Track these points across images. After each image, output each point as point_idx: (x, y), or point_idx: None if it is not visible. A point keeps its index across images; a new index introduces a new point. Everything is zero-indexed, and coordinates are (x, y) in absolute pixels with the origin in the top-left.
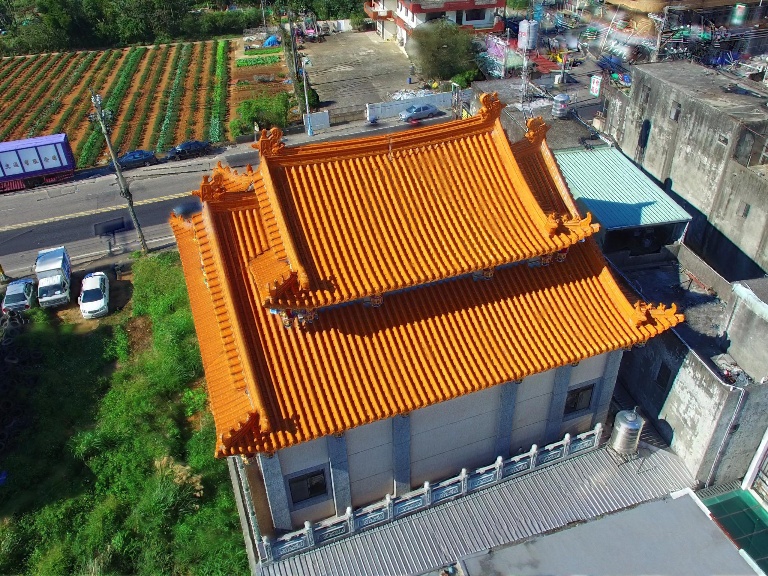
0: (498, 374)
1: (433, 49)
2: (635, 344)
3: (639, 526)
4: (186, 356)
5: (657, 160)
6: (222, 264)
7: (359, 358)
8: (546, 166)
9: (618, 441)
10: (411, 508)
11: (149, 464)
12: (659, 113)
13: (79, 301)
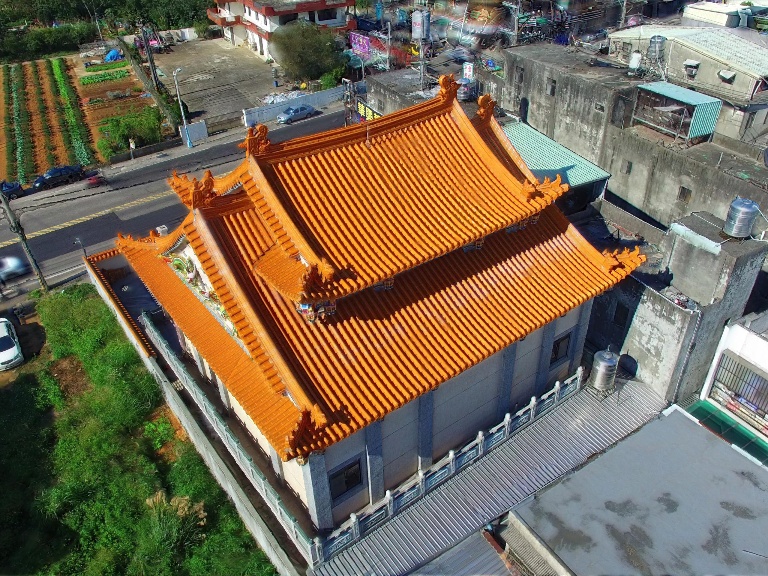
0: (511, 333)
1: (298, 50)
2: None
3: (648, 445)
4: (137, 388)
5: None
6: (230, 270)
7: (385, 341)
8: (498, 140)
9: (598, 380)
10: (439, 480)
11: (134, 506)
12: (535, 90)
13: None
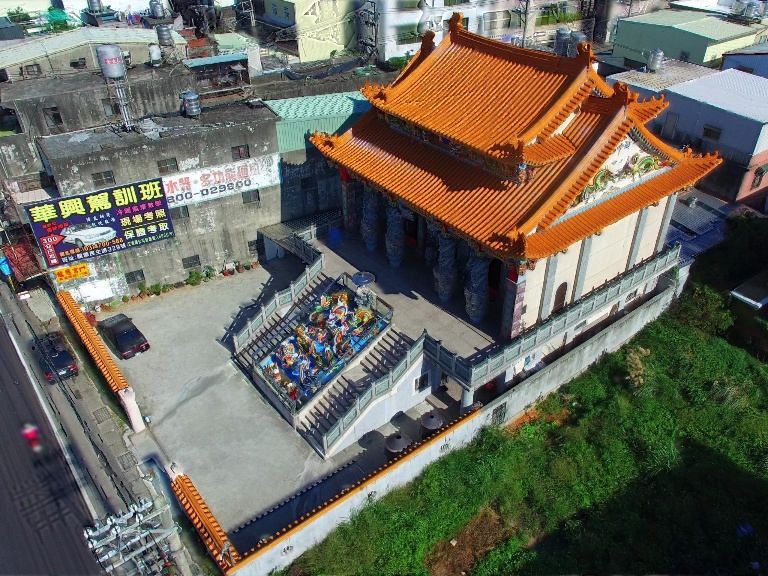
0: None
1: None
2: None
3: None
4: (503, 439)
5: None
6: None
7: None
8: None
9: None
10: None
11: None
12: (89, 120)
13: None
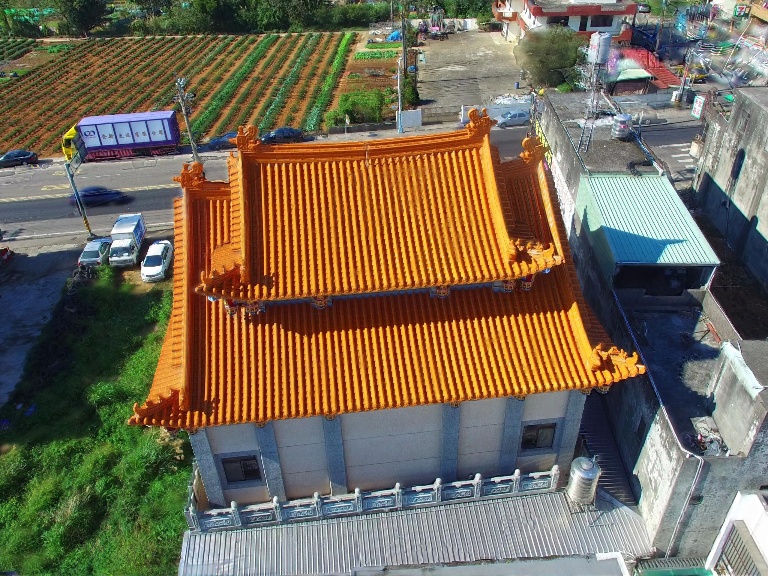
0: (425, 394)
1: (541, 55)
2: (597, 389)
3: None
4: None
5: (746, 194)
6: (187, 248)
7: (293, 355)
8: (539, 189)
9: (573, 488)
10: (341, 510)
11: None
12: (754, 143)
13: (142, 264)
